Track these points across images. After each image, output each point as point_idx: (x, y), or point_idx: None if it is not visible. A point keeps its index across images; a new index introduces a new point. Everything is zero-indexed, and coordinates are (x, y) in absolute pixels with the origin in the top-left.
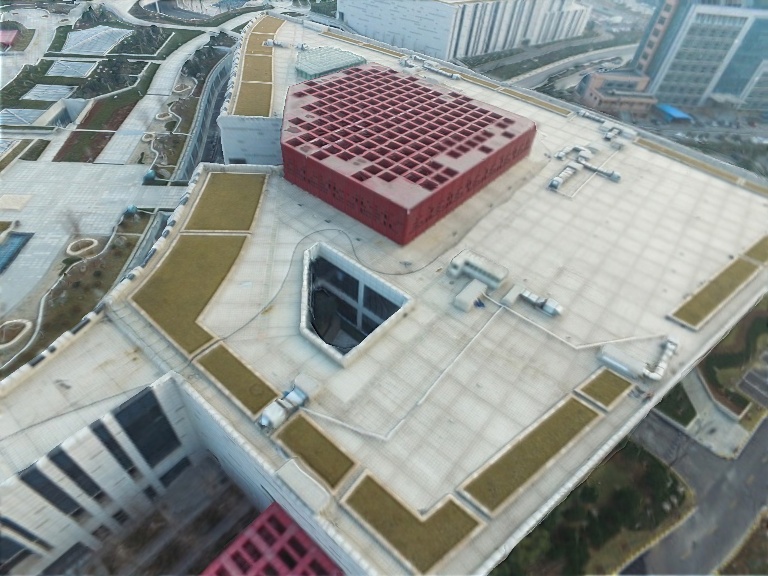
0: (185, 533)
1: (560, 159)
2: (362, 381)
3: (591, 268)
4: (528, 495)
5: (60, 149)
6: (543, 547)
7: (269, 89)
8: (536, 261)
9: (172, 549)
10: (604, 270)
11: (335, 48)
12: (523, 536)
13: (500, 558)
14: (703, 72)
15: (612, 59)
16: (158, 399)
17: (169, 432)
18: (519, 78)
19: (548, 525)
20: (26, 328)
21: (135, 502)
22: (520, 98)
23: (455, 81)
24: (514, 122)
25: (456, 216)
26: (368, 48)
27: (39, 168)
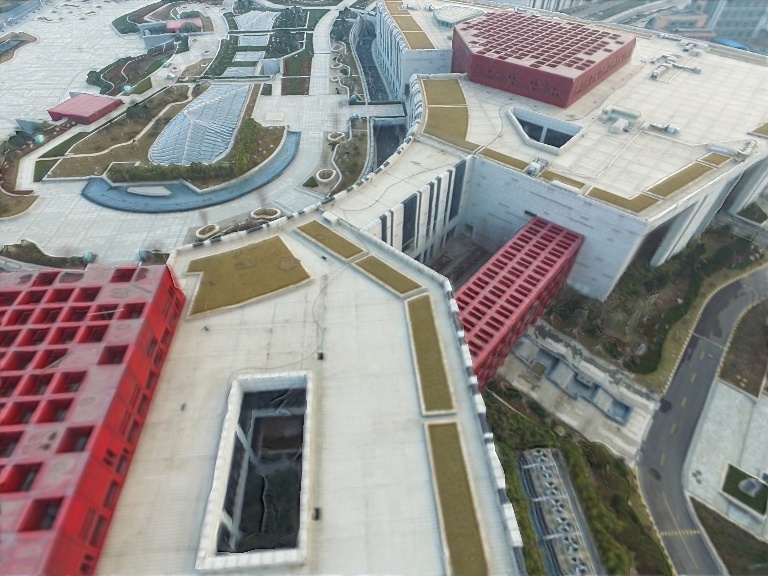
0: (464, 263)
1: (653, 63)
2: (572, 160)
3: (692, 114)
4: (682, 193)
5: (281, 88)
6: (677, 267)
7: (424, 35)
8: (654, 113)
9: (460, 268)
10: (701, 115)
11: (457, 6)
12: (685, 200)
13: (676, 207)
14: (756, 7)
15: (668, 8)
16: (465, 169)
17: (458, 200)
18: None
19: (678, 258)
20: (334, 172)
21: (438, 243)
22: None
23: None
24: (621, 36)
25: (592, 94)
26: (478, 6)
27: (277, 99)
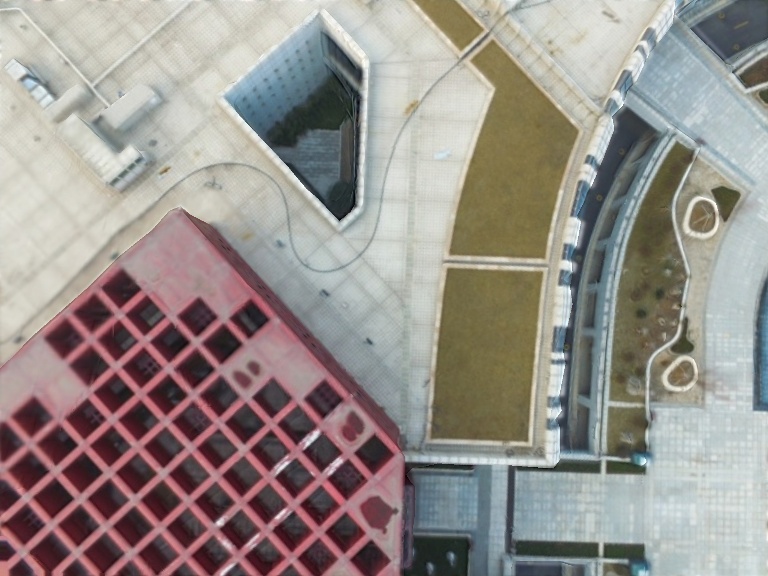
0: None
1: None
2: None
3: None
4: None
5: None
6: None
7: None
8: None
9: None
10: None
11: None
12: None
13: None
14: None
15: None
16: None
17: None
18: None
19: None
20: (687, 222)
21: None
22: None
23: None
24: None
25: None
26: None
27: None
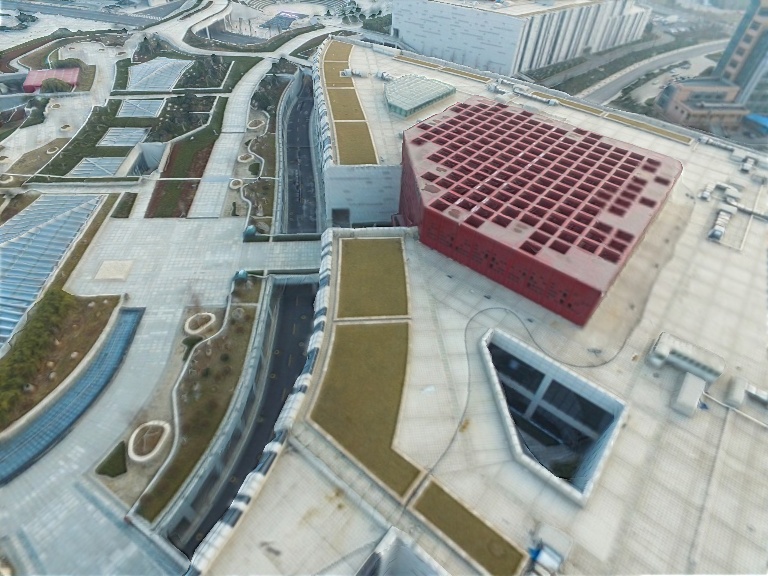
0: None
1: (705, 200)
2: (611, 527)
3: None
4: None
5: (149, 203)
6: None
7: (366, 129)
8: (738, 340)
9: None
10: None
11: (419, 76)
12: None
13: None
14: None
15: (680, 64)
16: (381, 563)
17: None
18: (589, 91)
19: None
20: (165, 432)
21: None
22: (631, 125)
23: (553, 107)
24: (660, 163)
25: (625, 282)
26: (449, 73)
27: (133, 227)
